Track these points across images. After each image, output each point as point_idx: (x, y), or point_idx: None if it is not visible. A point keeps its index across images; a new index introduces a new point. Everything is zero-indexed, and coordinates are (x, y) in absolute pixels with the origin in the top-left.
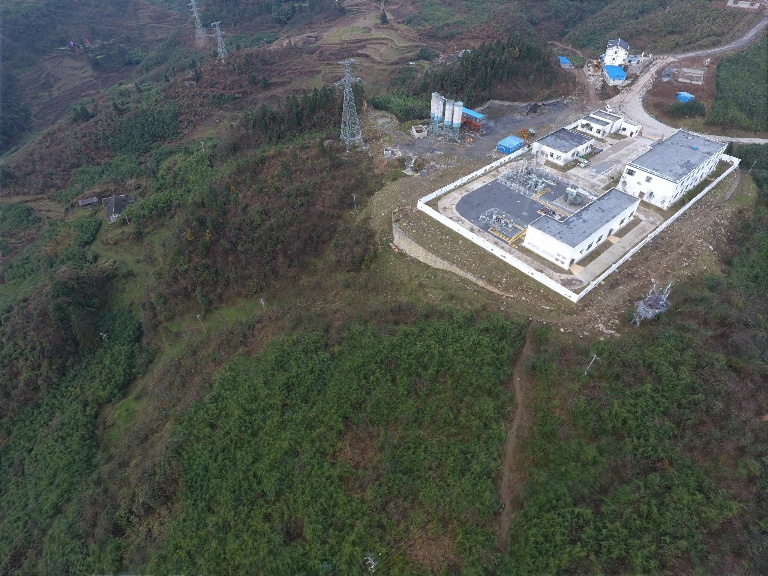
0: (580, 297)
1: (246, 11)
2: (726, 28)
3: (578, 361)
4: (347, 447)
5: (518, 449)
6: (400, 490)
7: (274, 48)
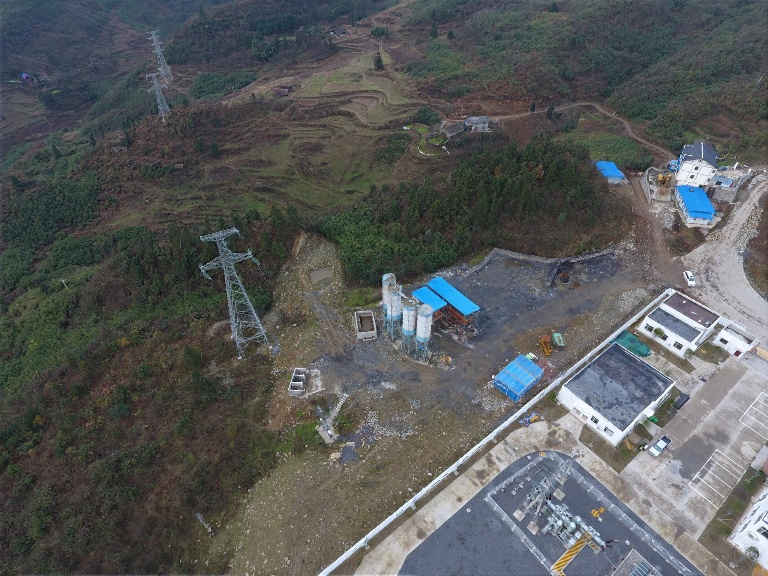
0: None
1: (222, 45)
2: None
3: None
4: None
5: None
6: None
7: (233, 103)
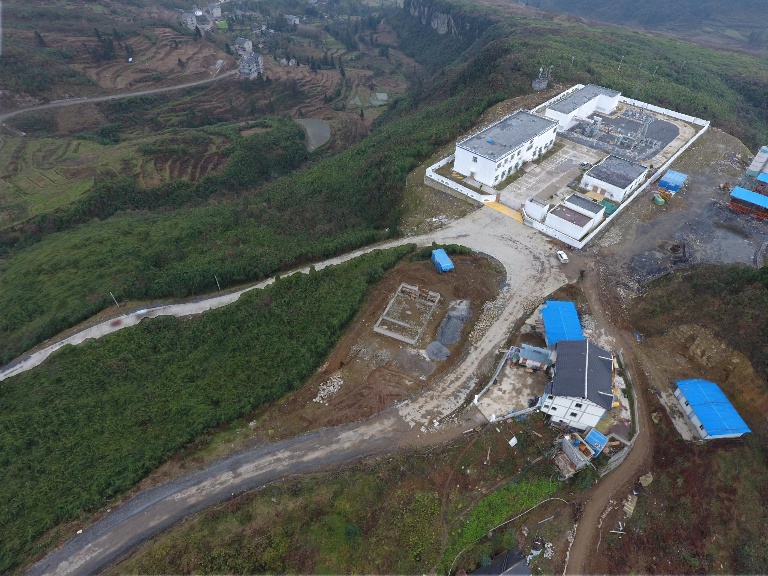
0: (576, 90)
1: None
2: (141, 574)
3: None
4: None
5: None
6: None
7: None
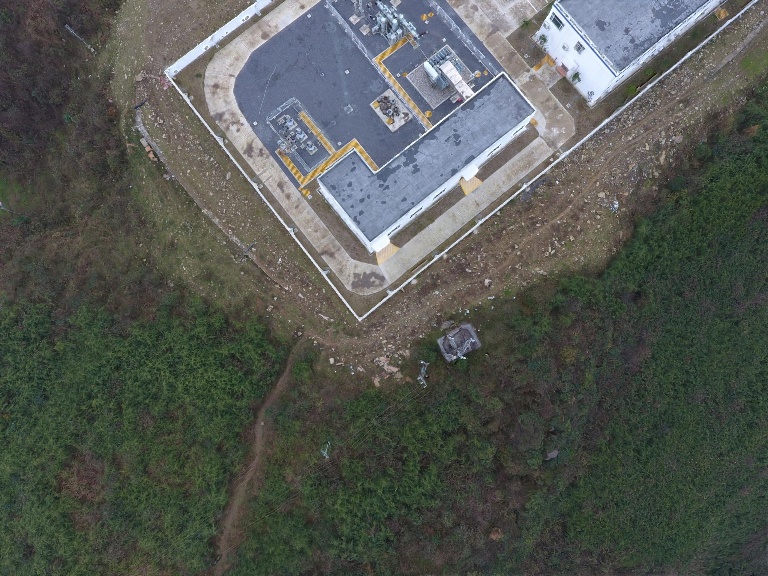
0: None
1: None
2: None
3: (330, 419)
4: (73, 477)
5: (243, 507)
6: (119, 537)
7: None
